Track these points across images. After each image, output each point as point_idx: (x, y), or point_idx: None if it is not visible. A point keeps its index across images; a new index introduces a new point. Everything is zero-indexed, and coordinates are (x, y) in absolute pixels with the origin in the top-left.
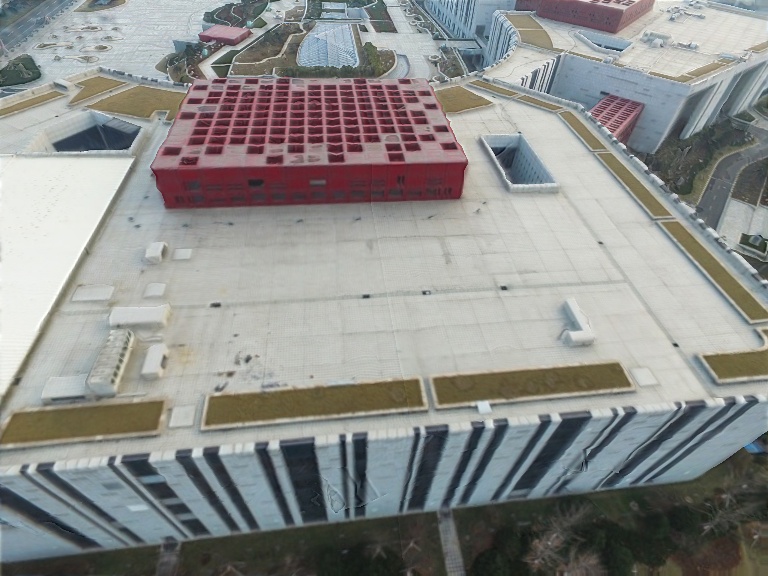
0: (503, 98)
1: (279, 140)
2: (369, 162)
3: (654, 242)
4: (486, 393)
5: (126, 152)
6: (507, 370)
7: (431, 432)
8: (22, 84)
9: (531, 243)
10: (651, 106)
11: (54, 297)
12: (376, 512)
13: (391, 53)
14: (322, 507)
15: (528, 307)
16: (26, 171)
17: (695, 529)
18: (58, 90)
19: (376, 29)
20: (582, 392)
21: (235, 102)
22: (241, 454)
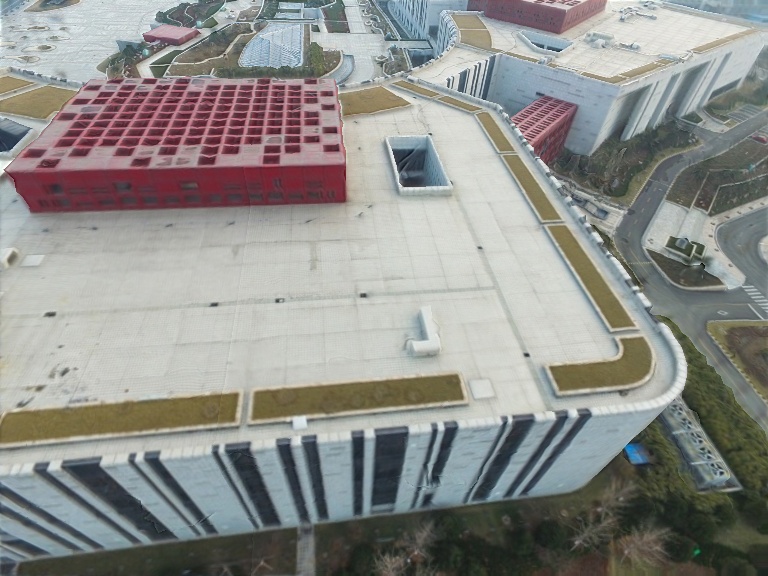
0: (424, 99)
1: (155, 142)
2: (240, 164)
3: (536, 247)
4: (306, 407)
5: (5, 154)
6: (336, 383)
7: (230, 450)
8: None
9: (406, 248)
10: (584, 107)
11: None
12: (228, 529)
13: (338, 53)
14: None
15: (382, 315)
16: None
17: (562, 544)
18: None
19: (329, 29)
20: (410, 406)
21: (123, 103)
22: (17, 475)
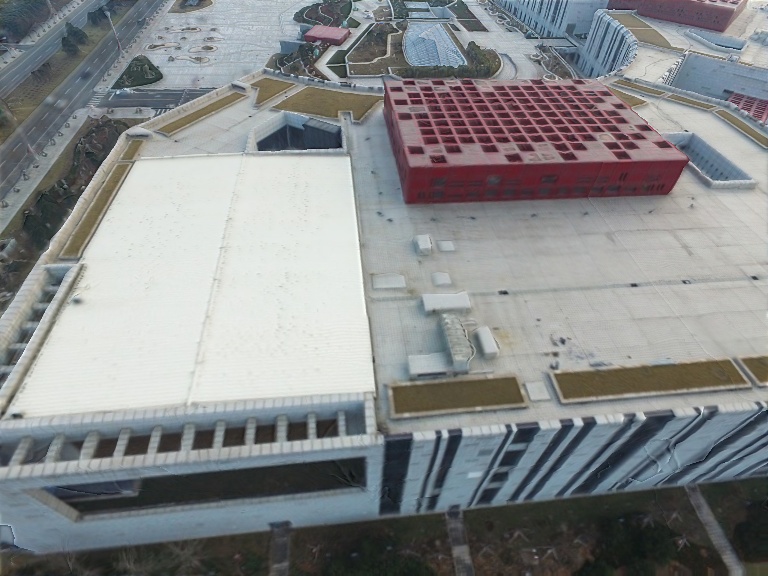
0: (652, 97)
1: (501, 139)
2: (600, 160)
3: None
4: None
5: (342, 151)
6: None
7: None
8: (149, 84)
9: (757, 236)
10: None
11: (361, 285)
12: (637, 485)
13: (493, 52)
14: (600, 479)
15: None
16: (263, 169)
17: None
18: (237, 91)
19: (467, 28)
20: None
21: (438, 103)
22: (615, 424)
